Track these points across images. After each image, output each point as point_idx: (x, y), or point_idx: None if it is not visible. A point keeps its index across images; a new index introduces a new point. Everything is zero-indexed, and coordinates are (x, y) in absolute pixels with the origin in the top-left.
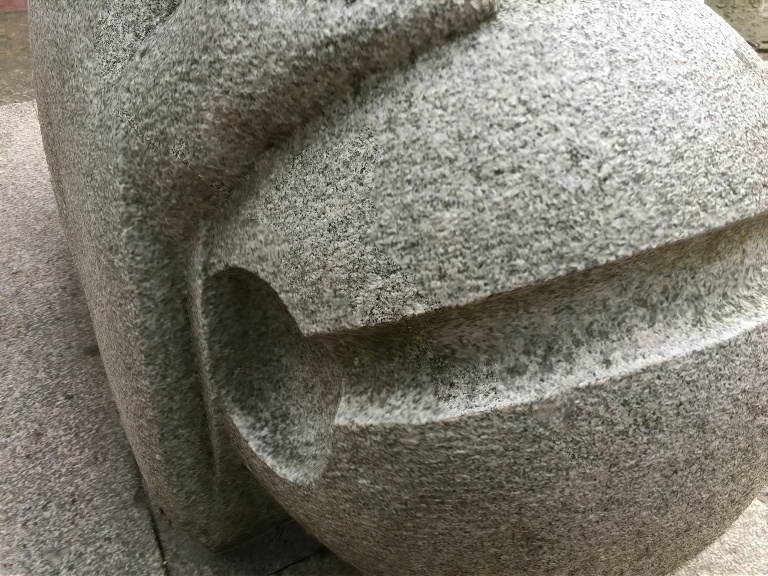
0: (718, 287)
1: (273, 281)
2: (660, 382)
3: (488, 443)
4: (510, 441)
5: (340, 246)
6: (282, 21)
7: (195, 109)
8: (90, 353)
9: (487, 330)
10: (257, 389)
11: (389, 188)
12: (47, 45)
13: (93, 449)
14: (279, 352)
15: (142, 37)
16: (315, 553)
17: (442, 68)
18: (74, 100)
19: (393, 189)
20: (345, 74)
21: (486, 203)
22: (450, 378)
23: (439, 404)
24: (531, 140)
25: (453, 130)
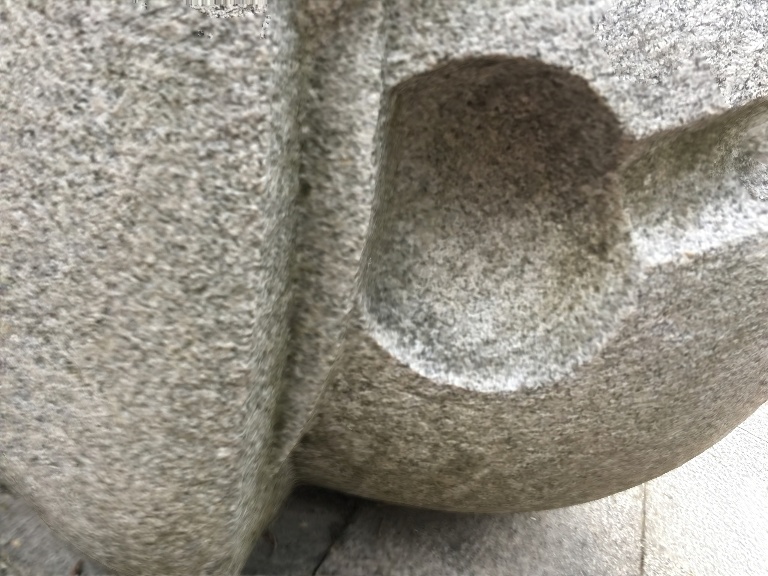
0: None
1: (579, 63)
2: None
3: None
4: None
5: None
6: None
7: None
8: None
9: None
10: (382, 290)
11: None
12: None
13: None
14: (405, 228)
15: None
16: (333, 542)
17: None
18: None
19: None
20: None
21: None
22: (760, 177)
23: None
24: None
25: None
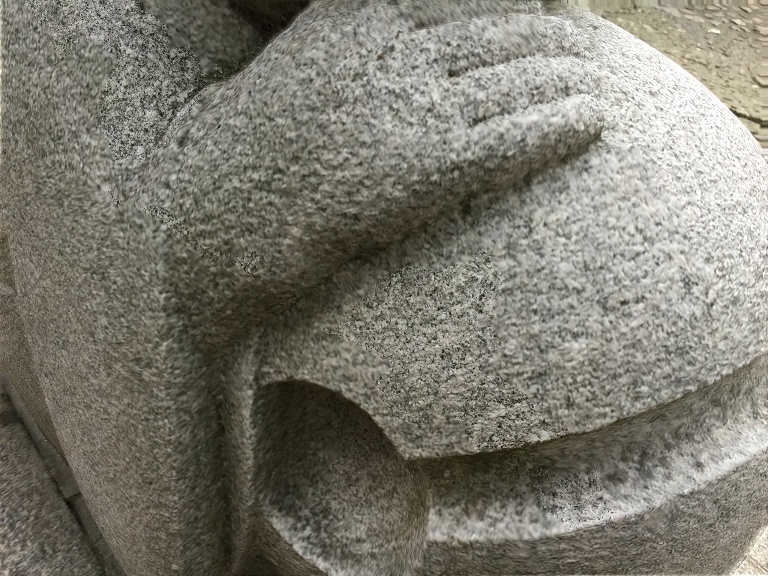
0: (763, 376)
1: (364, 402)
2: (744, 479)
3: (599, 551)
4: (620, 547)
5: (456, 373)
6: (401, 142)
7: (277, 223)
8: (2, 421)
9: (590, 441)
10: (292, 486)
11: (513, 317)
12: (5, 101)
13: (36, 540)
14: (316, 445)
15: (169, 117)
16: None
17: (560, 193)
18: (64, 179)
19: (517, 318)
20: (461, 196)
21: (614, 334)
22: (552, 488)
23: (547, 517)
24: (651, 270)
25: (579, 261)
